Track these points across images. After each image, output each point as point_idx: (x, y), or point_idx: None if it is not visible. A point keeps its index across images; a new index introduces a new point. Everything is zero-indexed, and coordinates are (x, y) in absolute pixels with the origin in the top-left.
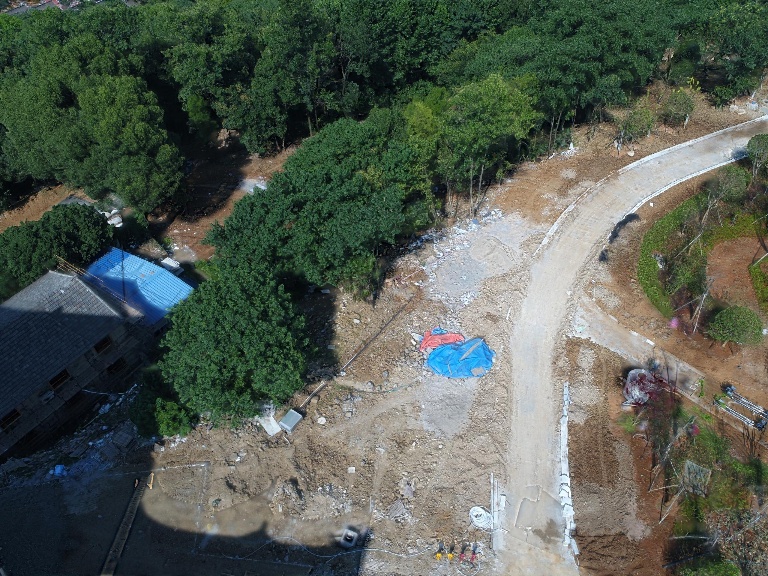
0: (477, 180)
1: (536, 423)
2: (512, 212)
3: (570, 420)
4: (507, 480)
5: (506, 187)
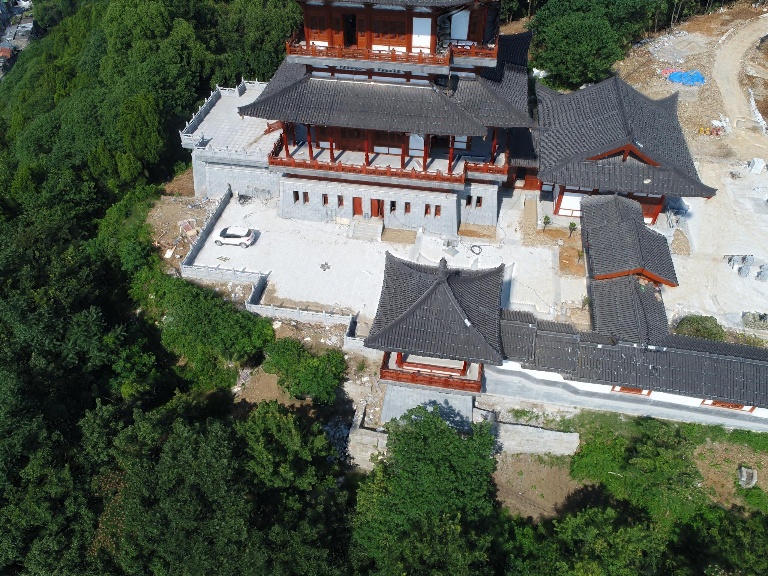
0: (661, 26)
1: (736, 100)
2: (694, 32)
3: (755, 99)
4: (727, 115)
5: (686, 23)
